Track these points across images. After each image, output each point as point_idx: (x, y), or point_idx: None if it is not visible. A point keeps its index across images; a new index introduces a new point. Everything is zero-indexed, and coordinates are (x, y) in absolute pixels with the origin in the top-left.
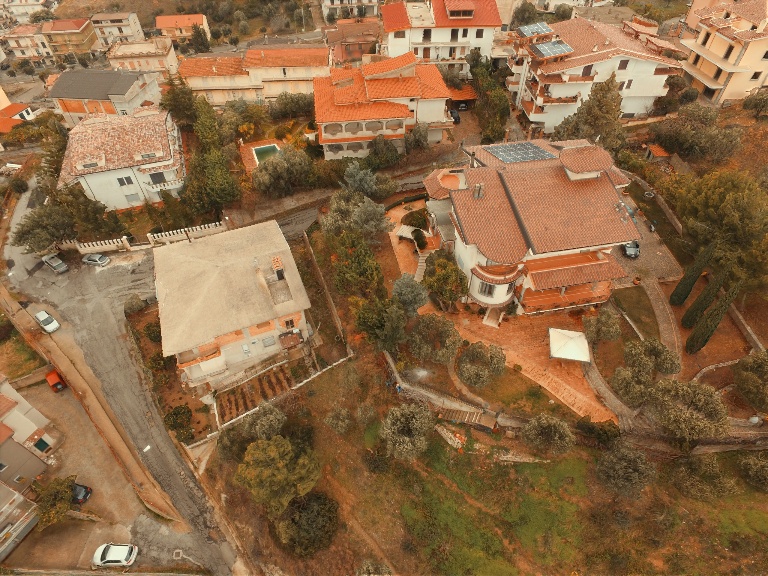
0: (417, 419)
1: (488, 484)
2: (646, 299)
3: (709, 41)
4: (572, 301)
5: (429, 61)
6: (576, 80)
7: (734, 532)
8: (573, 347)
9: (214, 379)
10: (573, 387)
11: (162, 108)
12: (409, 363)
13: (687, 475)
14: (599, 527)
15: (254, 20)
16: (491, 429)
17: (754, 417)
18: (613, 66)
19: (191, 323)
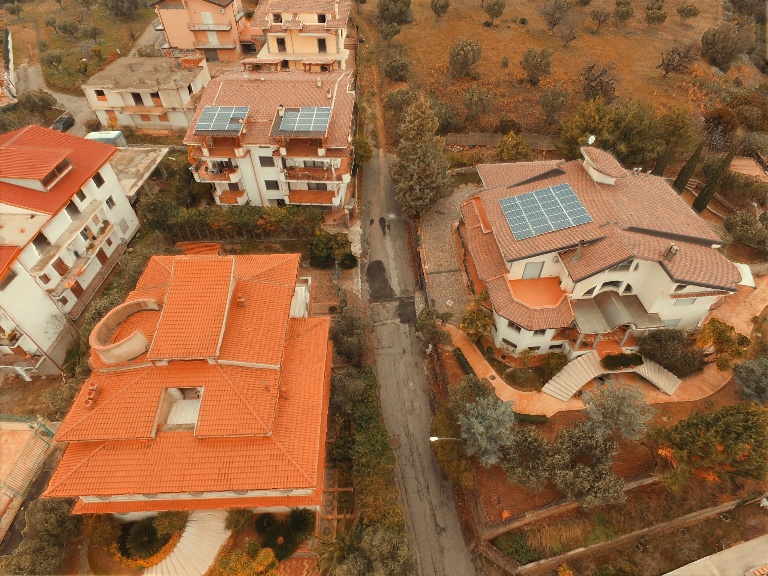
0: None
1: None
2: None
3: (288, 45)
4: None
5: None
6: None
7: None
8: (744, 269)
9: None
10: None
11: None
12: None
13: None
14: None
15: None
16: None
17: (754, 204)
18: None
19: None
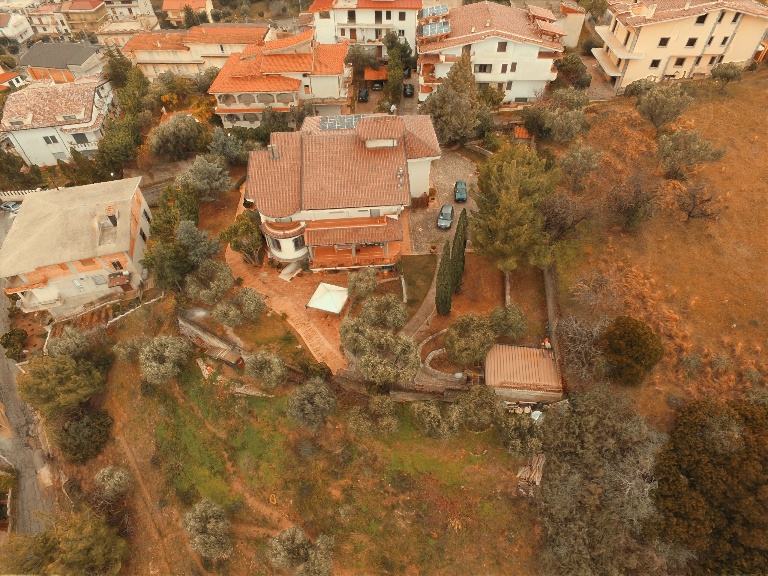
0: (168, 348)
1: (222, 412)
2: (433, 266)
3: (616, 28)
4: (358, 262)
5: (355, 42)
6: (453, 60)
7: (399, 470)
8: (327, 299)
9: (47, 308)
10: (325, 336)
11: (104, 77)
12: (185, 302)
13: (358, 412)
14: (299, 457)
15: (257, 4)
16: (236, 365)
17: (459, 373)
18: (492, 48)
19: (20, 254)
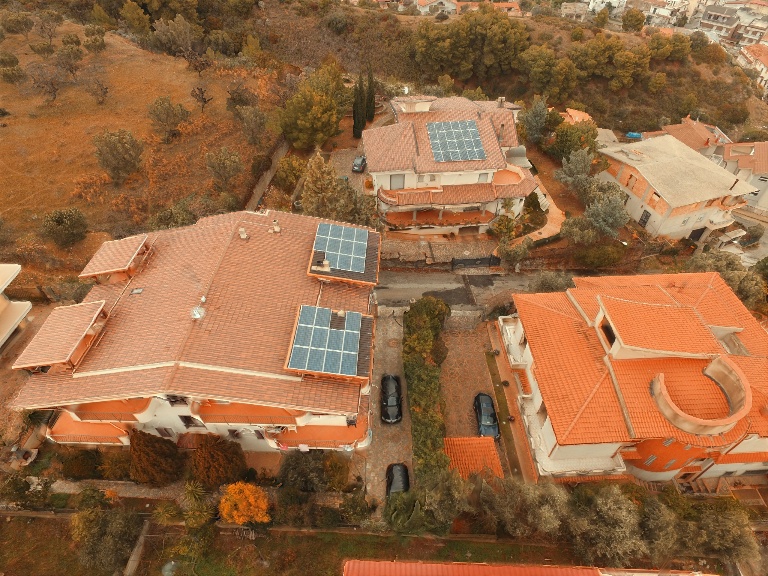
0: None
1: None
2: None
3: None
4: None
5: None
6: None
7: None
8: None
9: None
10: None
11: None
12: None
13: None
14: None
15: None
16: None
17: None
18: None
19: None
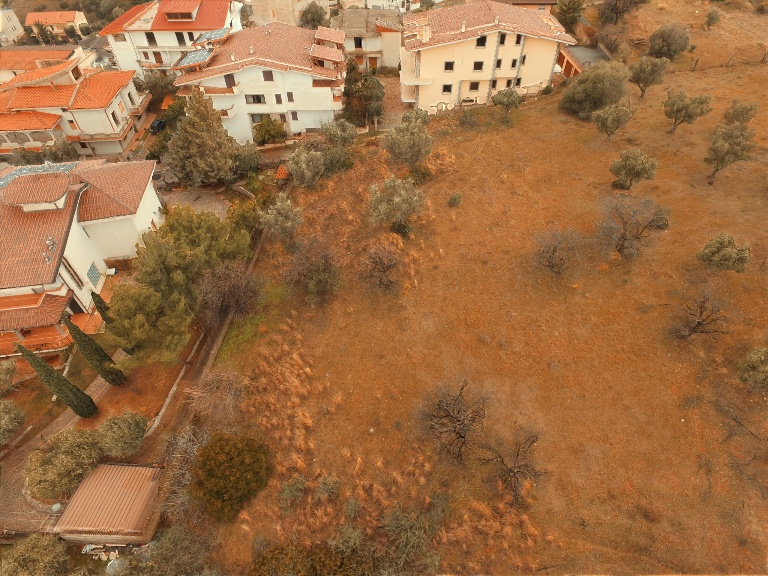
0: None
1: None
2: None
3: None
4: None
5: (160, 66)
6: (214, 92)
7: None
8: None
9: None
10: None
11: None
12: None
13: None
14: None
15: None
16: None
17: (56, 504)
18: (257, 77)
19: None
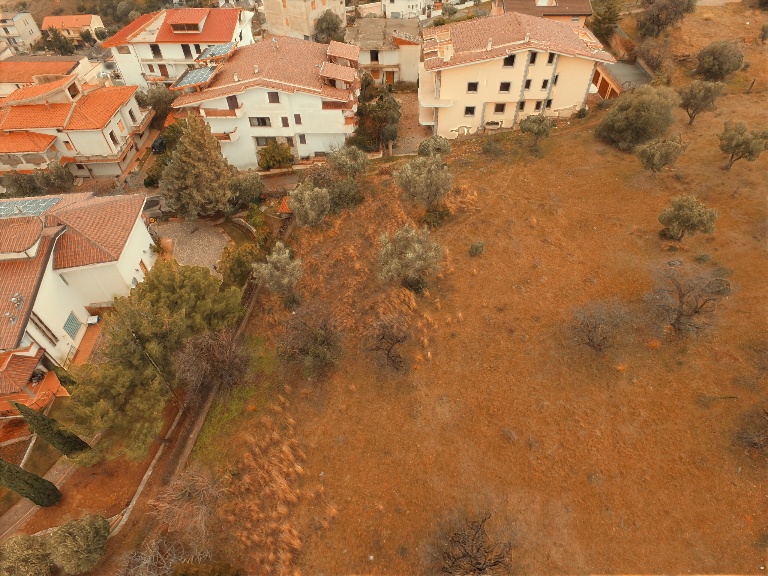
0: None
1: None
2: None
3: None
4: None
5: (165, 79)
6: (215, 115)
7: None
8: None
9: None
10: None
11: None
12: None
13: None
14: None
15: None
16: None
17: None
18: (262, 99)
19: None
